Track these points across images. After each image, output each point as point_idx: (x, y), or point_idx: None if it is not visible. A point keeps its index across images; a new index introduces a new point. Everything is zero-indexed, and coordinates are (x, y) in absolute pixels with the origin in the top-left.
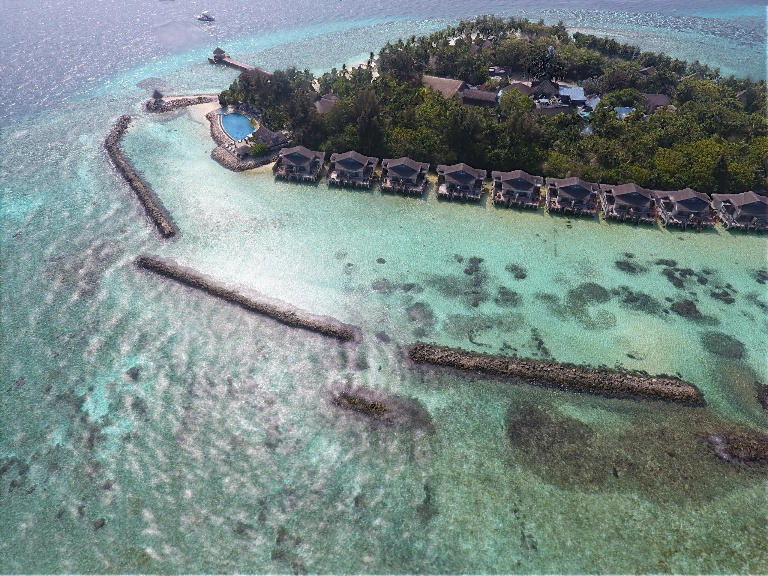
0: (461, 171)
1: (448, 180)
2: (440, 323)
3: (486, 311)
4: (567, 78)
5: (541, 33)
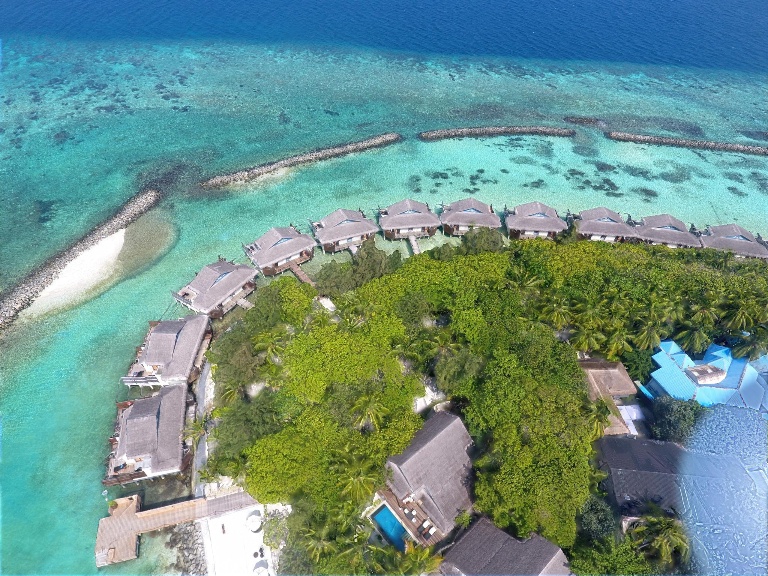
0: None
1: None
2: None
3: (744, 170)
4: None
5: None
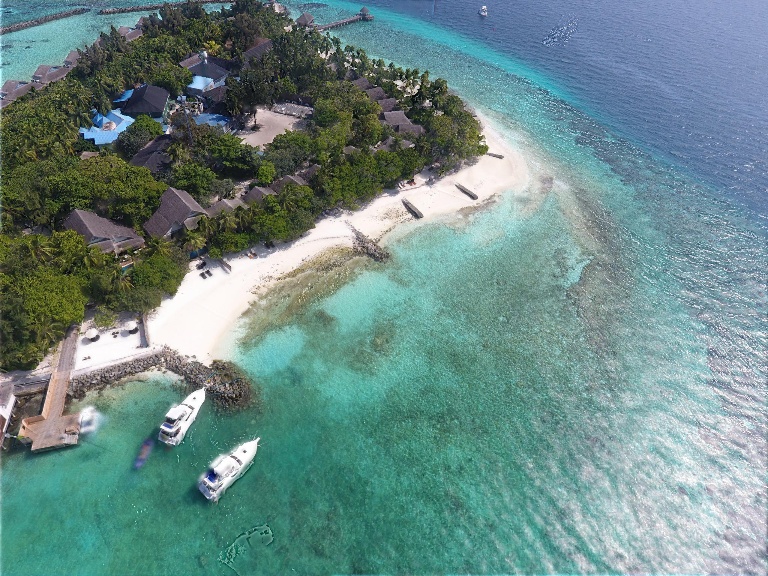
0: None
1: None
2: None
3: None
4: None
5: (432, 134)
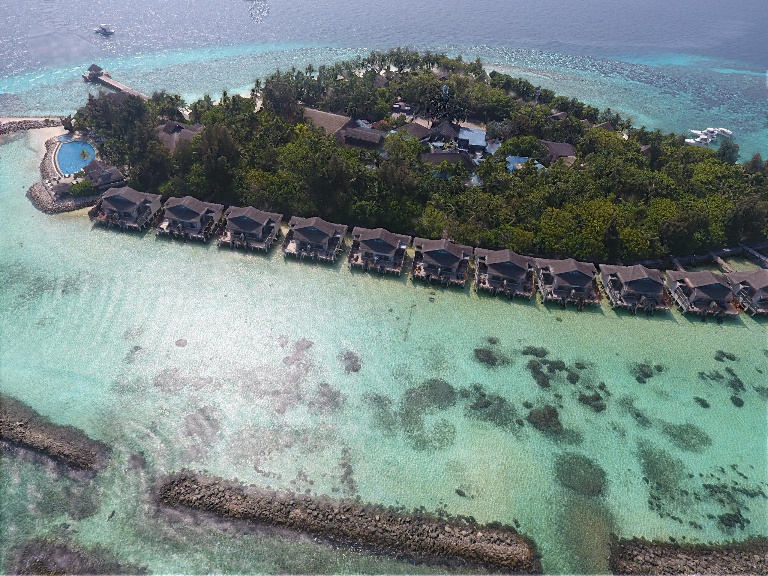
0: (312, 227)
1: (297, 237)
2: (224, 439)
3: (292, 420)
4: (477, 119)
5: (458, 69)
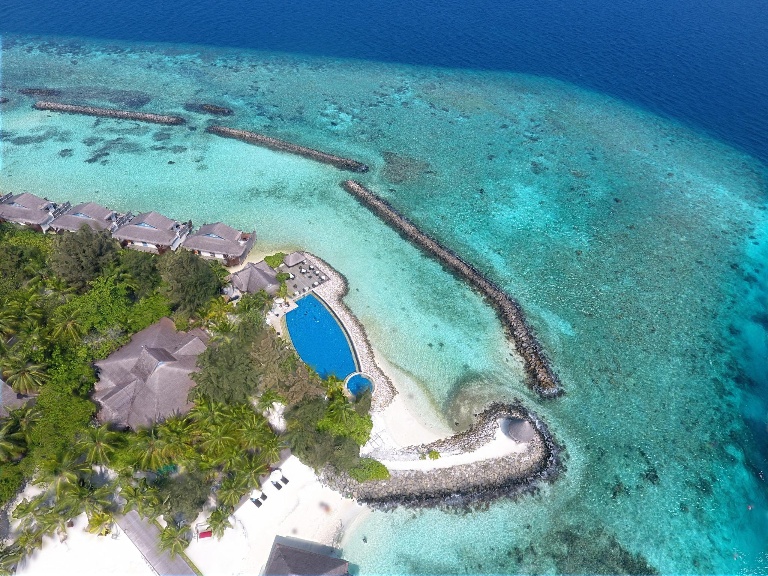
0: None
1: None
2: (152, 132)
3: (116, 135)
4: None
5: None
